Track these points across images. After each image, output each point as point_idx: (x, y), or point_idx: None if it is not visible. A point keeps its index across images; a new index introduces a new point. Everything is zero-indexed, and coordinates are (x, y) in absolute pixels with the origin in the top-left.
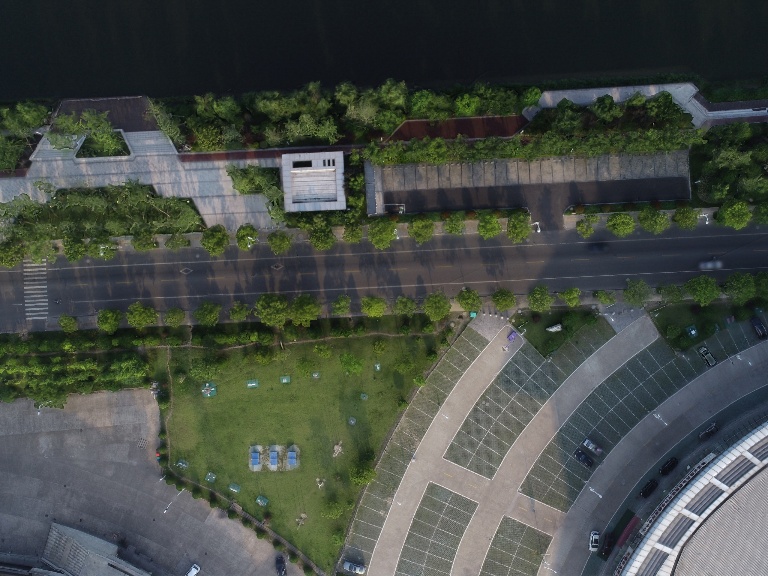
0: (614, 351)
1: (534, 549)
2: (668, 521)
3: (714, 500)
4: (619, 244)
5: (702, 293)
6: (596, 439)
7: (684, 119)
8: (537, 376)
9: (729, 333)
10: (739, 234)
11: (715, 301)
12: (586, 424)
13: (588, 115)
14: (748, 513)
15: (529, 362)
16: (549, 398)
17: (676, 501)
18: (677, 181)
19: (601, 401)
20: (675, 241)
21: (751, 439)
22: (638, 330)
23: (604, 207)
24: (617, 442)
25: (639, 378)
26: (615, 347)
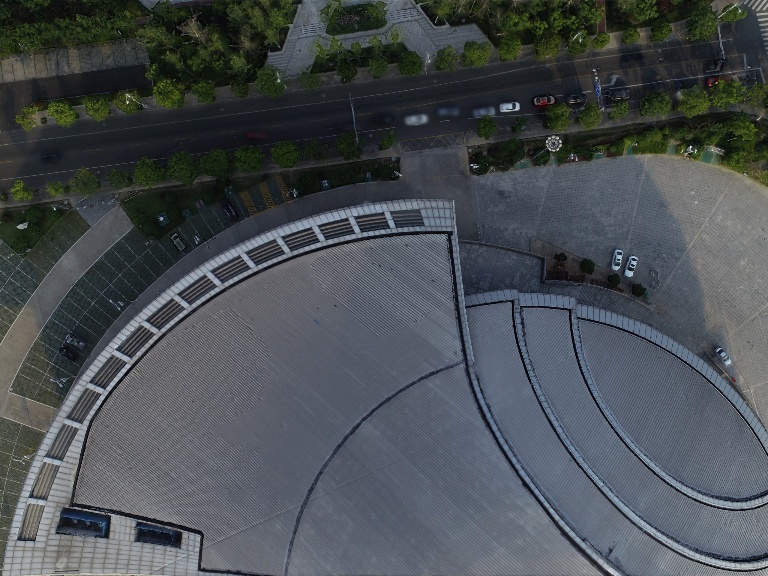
0: (90, 245)
1: (30, 447)
2: (74, 396)
3: (118, 372)
4: (86, 137)
5: (139, 175)
6: (80, 333)
7: (130, 5)
8: (16, 275)
9: (202, 217)
10: (204, 117)
11: (185, 187)
12: (69, 319)
13: (16, 6)
14: (150, 382)
15: (7, 262)
16: (30, 296)
17: (81, 376)
18: (137, 69)
19: (82, 295)
20: (141, 130)
21: (148, 309)
22: (112, 222)
23: (61, 101)
24: (102, 335)
25: (117, 269)
26: (91, 240)
